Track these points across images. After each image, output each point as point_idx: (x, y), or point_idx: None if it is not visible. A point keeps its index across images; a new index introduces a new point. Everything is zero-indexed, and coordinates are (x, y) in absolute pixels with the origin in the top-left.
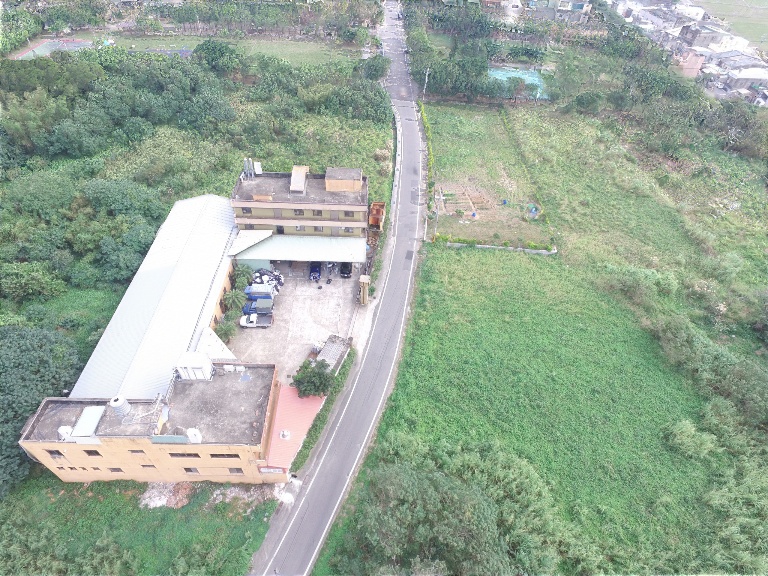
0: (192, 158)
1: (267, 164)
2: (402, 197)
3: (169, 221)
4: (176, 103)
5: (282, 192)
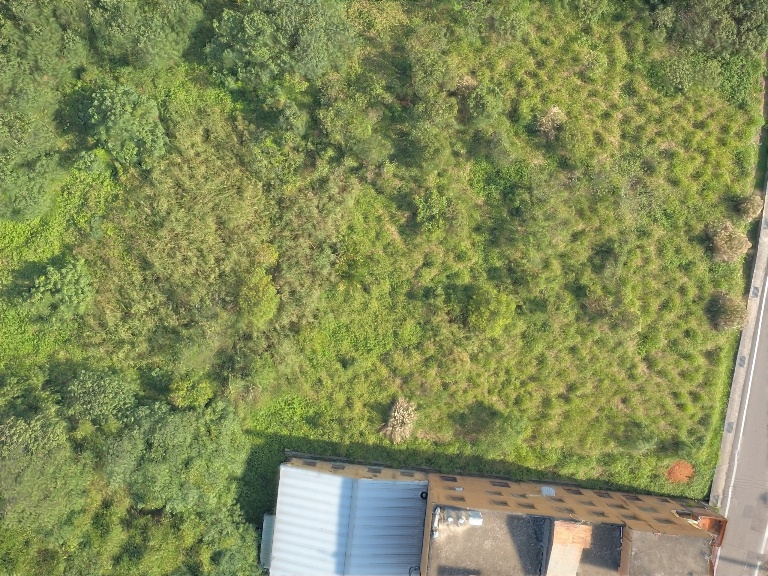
0: (278, 263)
1: (452, 296)
2: (752, 409)
3: (283, 540)
4: (196, 14)
5: (524, 574)
